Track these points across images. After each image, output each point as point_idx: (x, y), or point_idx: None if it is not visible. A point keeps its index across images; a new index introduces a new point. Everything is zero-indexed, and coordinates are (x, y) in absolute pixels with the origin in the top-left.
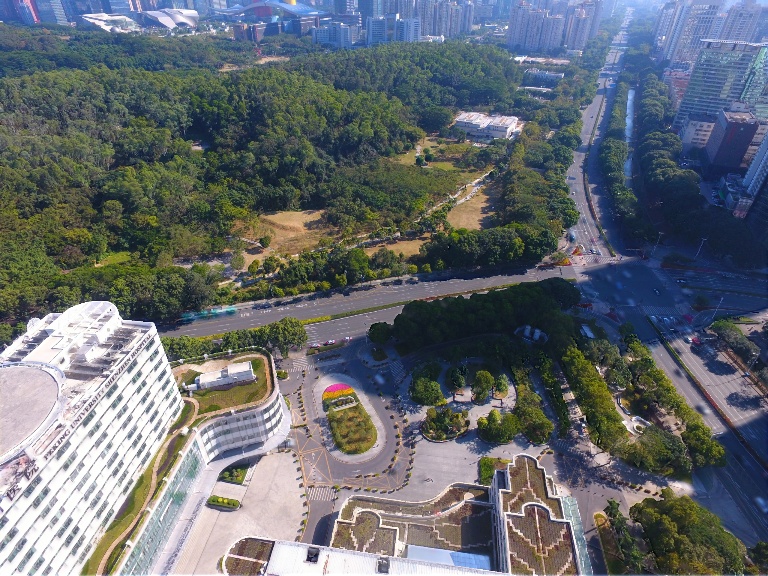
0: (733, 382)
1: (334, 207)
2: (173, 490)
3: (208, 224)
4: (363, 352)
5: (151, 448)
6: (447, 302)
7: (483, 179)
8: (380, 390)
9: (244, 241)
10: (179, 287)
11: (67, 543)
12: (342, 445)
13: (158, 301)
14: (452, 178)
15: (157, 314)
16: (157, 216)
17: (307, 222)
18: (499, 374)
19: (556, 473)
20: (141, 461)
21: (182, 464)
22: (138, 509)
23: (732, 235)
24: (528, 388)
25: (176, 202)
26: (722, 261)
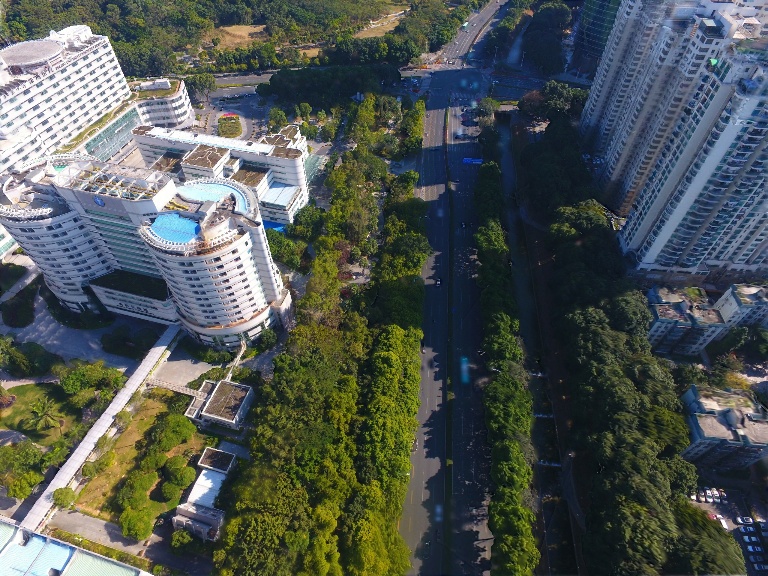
0: (470, 129)
1: (270, 21)
2: (122, 123)
3: (179, 28)
4: (254, 102)
5: (112, 104)
6: (302, 69)
7: (404, 10)
8: (254, 117)
9: (204, 42)
10: (147, 55)
11: (70, 116)
12: (221, 134)
13: (134, 62)
14: (377, 7)
15: (134, 71)
16: (144, 19)
17: (251, 33)
18: (327, 115)
19: (327, 152)
20: (106, 106)
21: (127, 114)
22: (104, 122)
23: (543, 49)
24: (333, 117)
25: (157, 10)
26: (537, 71)
